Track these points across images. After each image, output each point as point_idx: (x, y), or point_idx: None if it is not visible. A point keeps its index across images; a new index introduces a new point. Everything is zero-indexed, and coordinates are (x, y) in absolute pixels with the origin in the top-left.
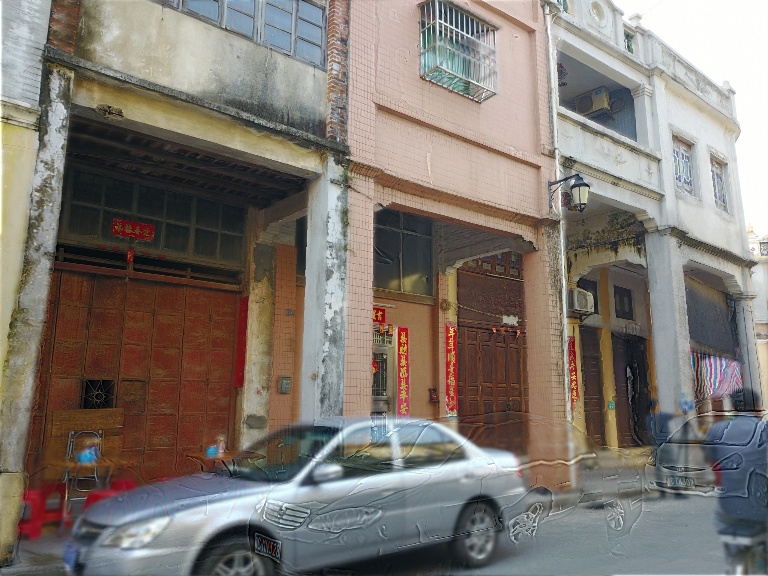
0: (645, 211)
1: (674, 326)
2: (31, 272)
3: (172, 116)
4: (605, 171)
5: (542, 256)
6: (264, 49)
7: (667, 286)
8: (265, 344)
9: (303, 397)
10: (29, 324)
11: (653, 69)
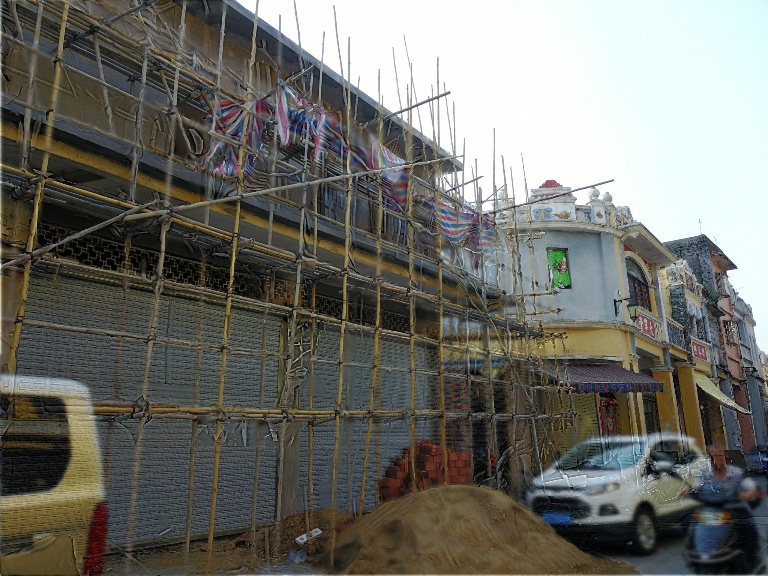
0: (749, 369)
1: (761, 410)
2: (723, 414)
3: (718, 373)
4: (745, 358)
5: (743, 392)
6: (718, 349)
7: (757, 396)
8: (681, 422)
9: (729, 439)
10: (725, 425)
11: (745, 314)
